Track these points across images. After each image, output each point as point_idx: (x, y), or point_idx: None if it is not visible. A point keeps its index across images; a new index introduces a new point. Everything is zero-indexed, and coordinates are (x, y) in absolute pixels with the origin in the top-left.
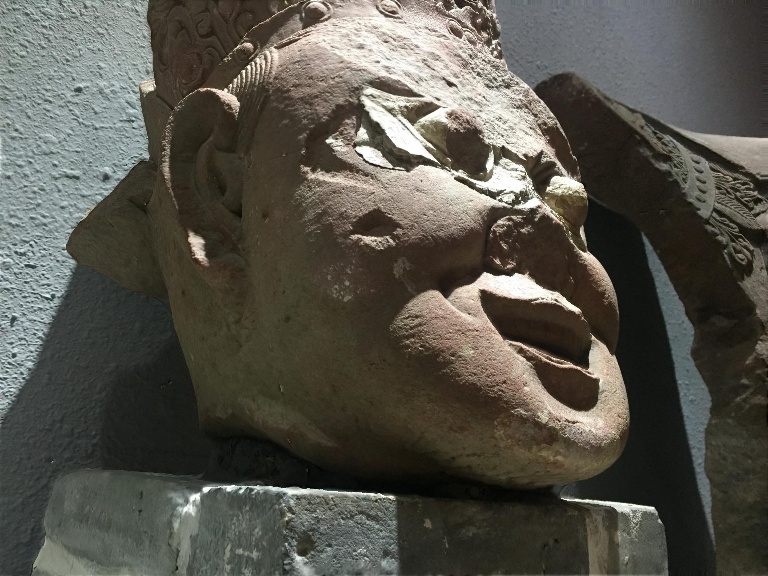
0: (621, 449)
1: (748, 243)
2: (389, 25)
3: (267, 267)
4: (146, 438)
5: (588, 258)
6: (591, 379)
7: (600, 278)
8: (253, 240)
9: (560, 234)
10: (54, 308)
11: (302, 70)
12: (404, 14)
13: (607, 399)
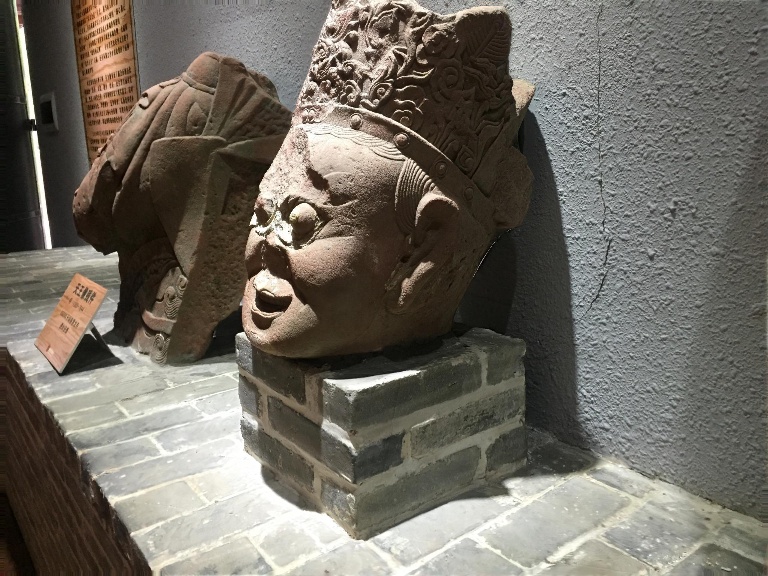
0: (278, 349)
1: None
2: None
3: None
4: None
5: (293, 254)
6: (263, 318)
7: (294, 265)
8: None
9: (273, 249)
10: None
11: None
12: None
13: (274, 326)
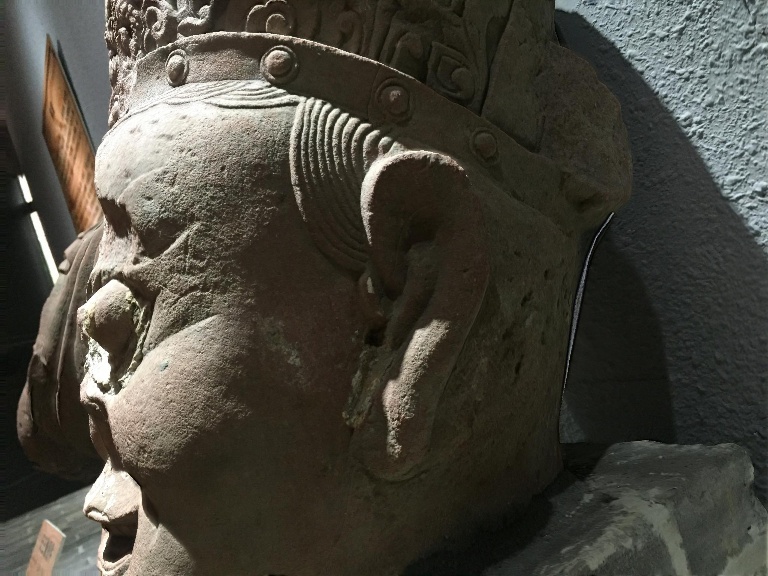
0: None
1: None
2: None
3: None
4: (582, 371)
5: None
6: None
7: None
8: None
9: (88, 409)
10: None
11: None
12: None
13: None
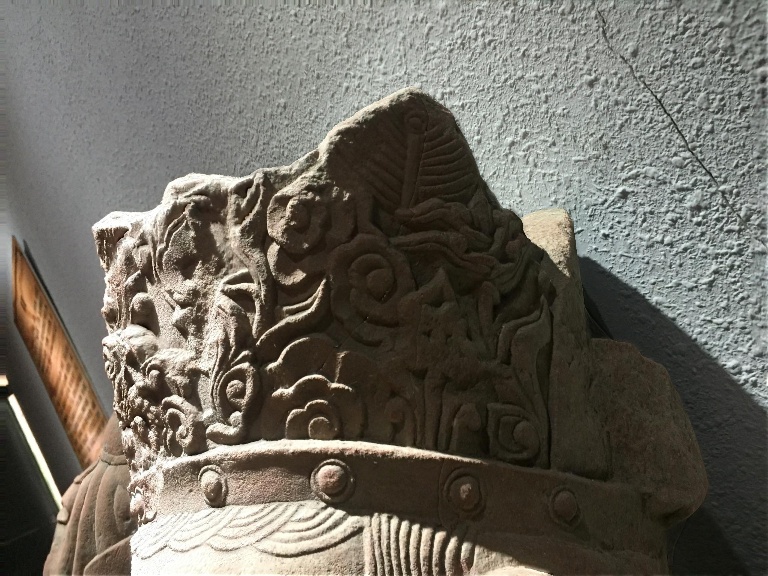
0: None
1: None
2: None
3: None
4: None
5: None
6: None
7: None
8: None
9: None
10: None
11: None
12: None
13: None
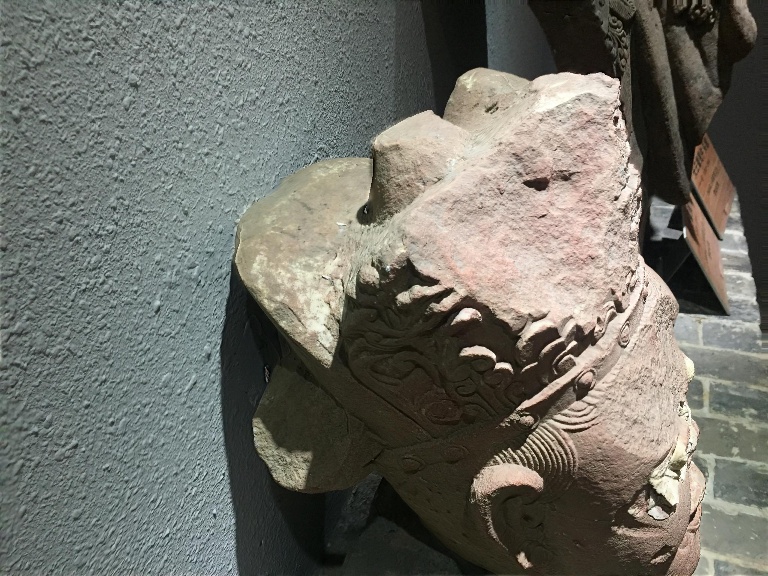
0: None
1: (626, 37)
2: (631, 362)
3: (581, 566)
4: None
5: None
6: None
7: None
8: (562, 548)
9: None
10: (227, 478)
11: (607, 469)
12: (630, 328)
13: None
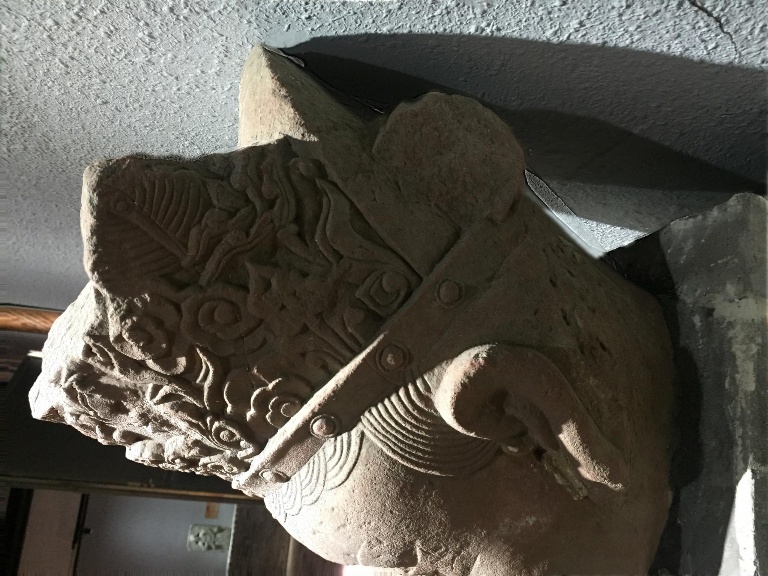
0: None
1: None
2: None
3: None
4: (571, 166)
5: None
6: None
7: None
8: None
9: None
10: None
11: None
12: None
13: None
